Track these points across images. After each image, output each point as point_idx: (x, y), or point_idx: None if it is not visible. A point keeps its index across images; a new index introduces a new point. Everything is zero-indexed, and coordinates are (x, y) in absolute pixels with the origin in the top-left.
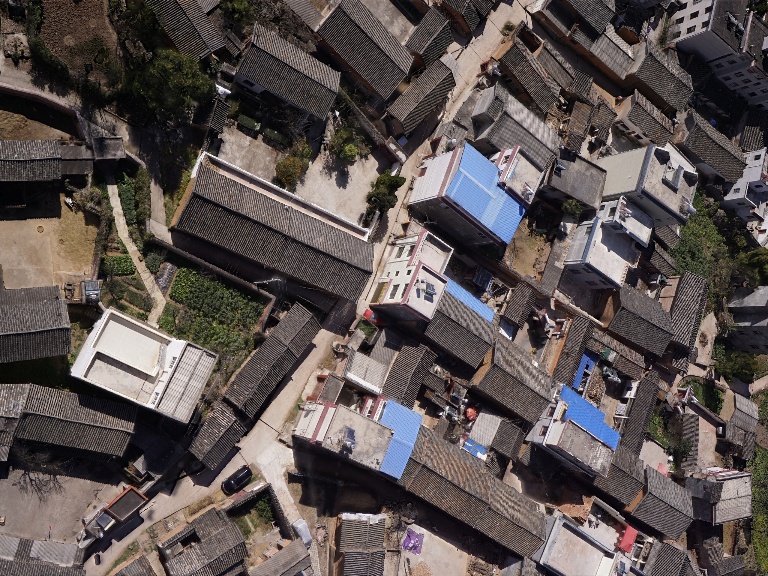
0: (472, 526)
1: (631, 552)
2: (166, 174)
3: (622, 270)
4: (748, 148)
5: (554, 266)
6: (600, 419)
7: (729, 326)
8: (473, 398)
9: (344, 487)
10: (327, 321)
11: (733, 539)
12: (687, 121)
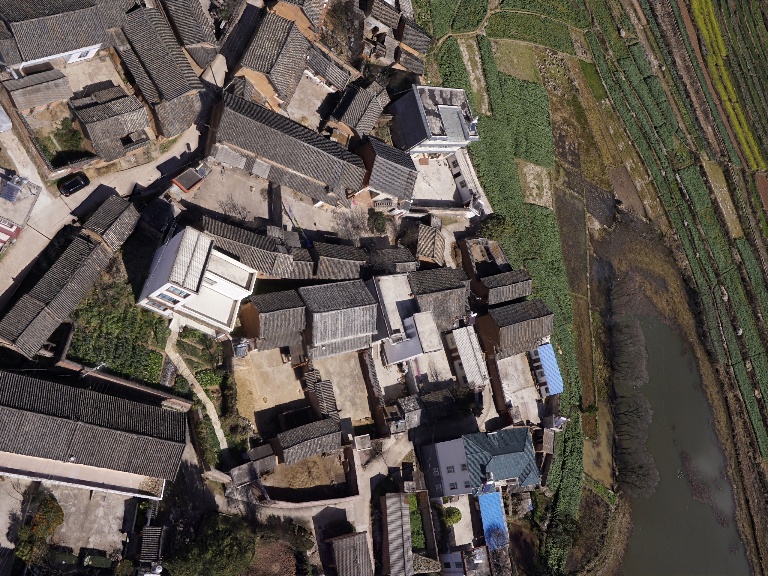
0: None
1: None
2: (178, 474)
3: None
4: None
5: None
6: None
7: None
8: None
9: None
10: None
11: None
12: None
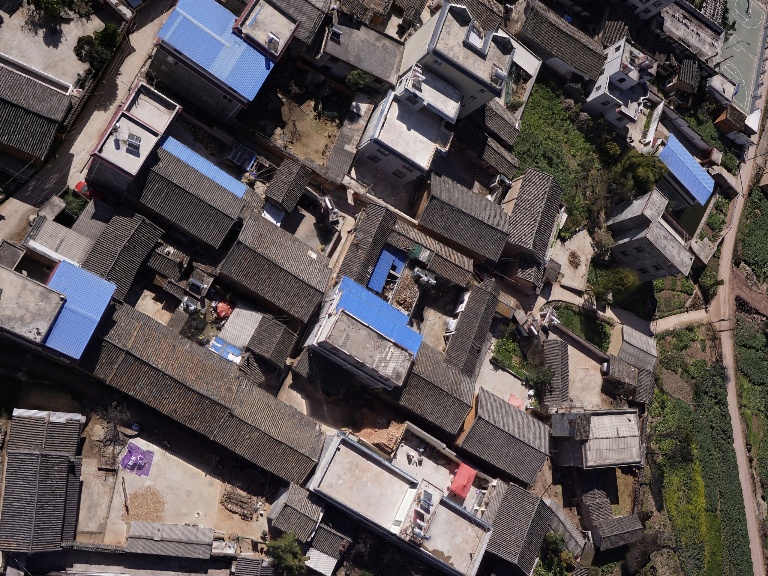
0: (209, 437)
1: (474, 500)
2: None
3: (429, 153)
4: (610, 44)
5: (343, 150)
6: None
7: (605, 244)
8: (226, 291)
9: (32, 384)
10: (23, 191)
11: (632, 500)
12: (526, 9)
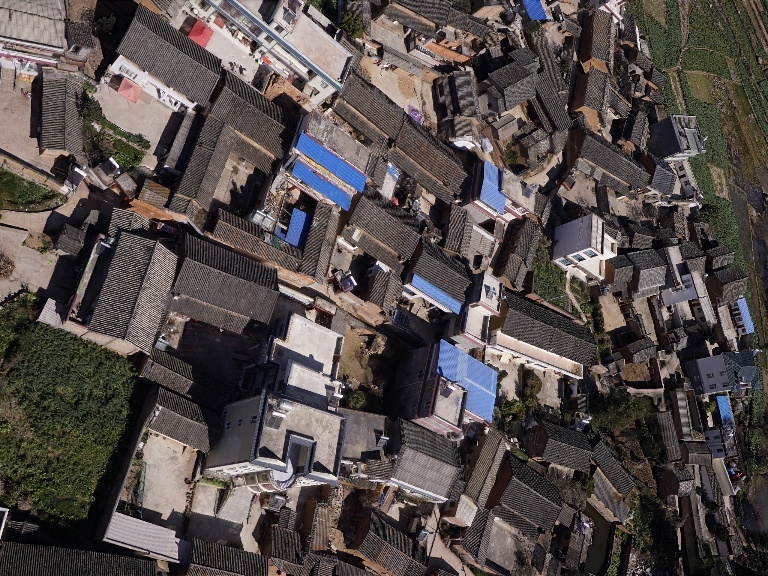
0: None
1: None
2: None
3: None
4: None
5: None
6: (299, 170)
7: None
8: None
9: None
10: None
11: None
12: None
